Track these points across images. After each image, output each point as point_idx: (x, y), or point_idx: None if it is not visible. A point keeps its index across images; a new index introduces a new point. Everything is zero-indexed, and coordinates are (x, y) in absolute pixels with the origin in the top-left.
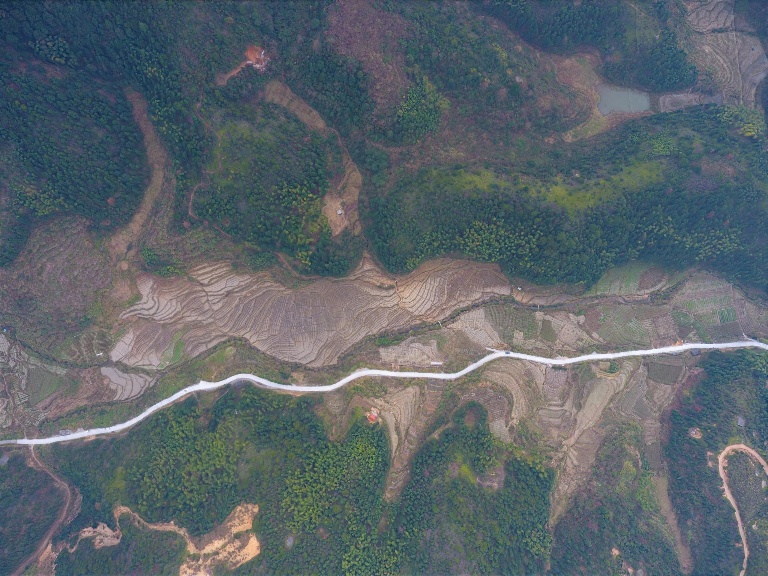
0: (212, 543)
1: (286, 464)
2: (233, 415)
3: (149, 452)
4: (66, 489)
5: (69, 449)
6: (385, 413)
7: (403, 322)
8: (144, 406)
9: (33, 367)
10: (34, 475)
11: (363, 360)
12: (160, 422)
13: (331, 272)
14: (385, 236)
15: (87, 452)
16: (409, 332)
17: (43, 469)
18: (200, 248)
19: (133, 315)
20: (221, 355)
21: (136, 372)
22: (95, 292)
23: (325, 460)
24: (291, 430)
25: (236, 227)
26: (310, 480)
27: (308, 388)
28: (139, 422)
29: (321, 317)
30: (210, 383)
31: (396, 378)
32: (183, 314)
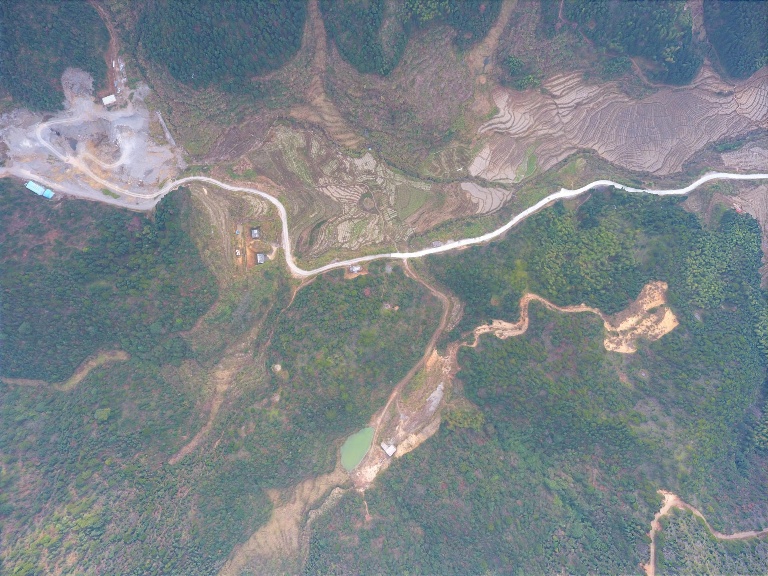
0: (626, 321)
1: (682, 246)
2: (614, 209)
3: (541, 246)
4: (443, 298)
5: (450, 255)
6: (746, 208)
7: (741, 128)
8: (510, 215)
9: (399, 183)
10: (416, 283)
11: (708, 165)
12: (543, 221)
13: (681, 76)
14: (741, 32)
15: (474, 254)
16: (746, 138)
17: (419, 280)
18: (560, 56)
19: (490, 129)
20: (573, 166)
21: (493, 186)
22: (458, 105)
23: (711, 245)
24: (677, 217)
25: (602, 29)
26: (703, 262)
27: (663, 192)
28: (515, 226)
29: (664, 126)
30: (570, 191)
31: (744, 179)
32: (535, 128)
